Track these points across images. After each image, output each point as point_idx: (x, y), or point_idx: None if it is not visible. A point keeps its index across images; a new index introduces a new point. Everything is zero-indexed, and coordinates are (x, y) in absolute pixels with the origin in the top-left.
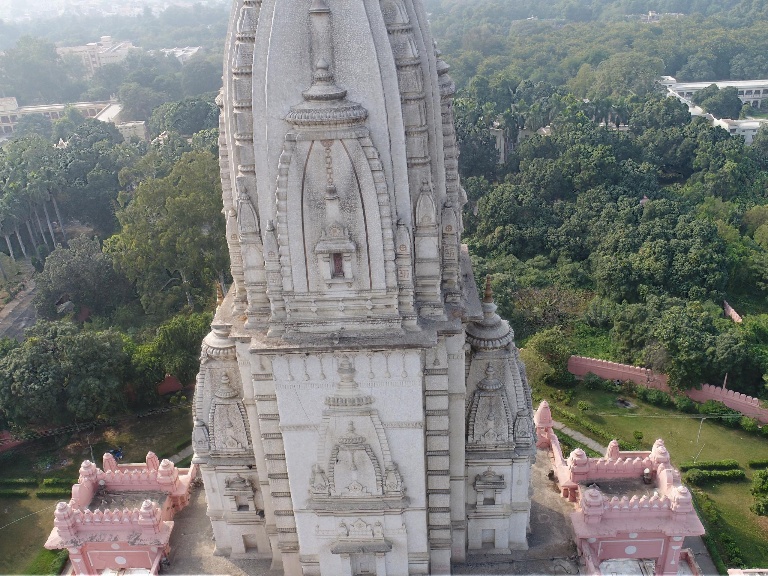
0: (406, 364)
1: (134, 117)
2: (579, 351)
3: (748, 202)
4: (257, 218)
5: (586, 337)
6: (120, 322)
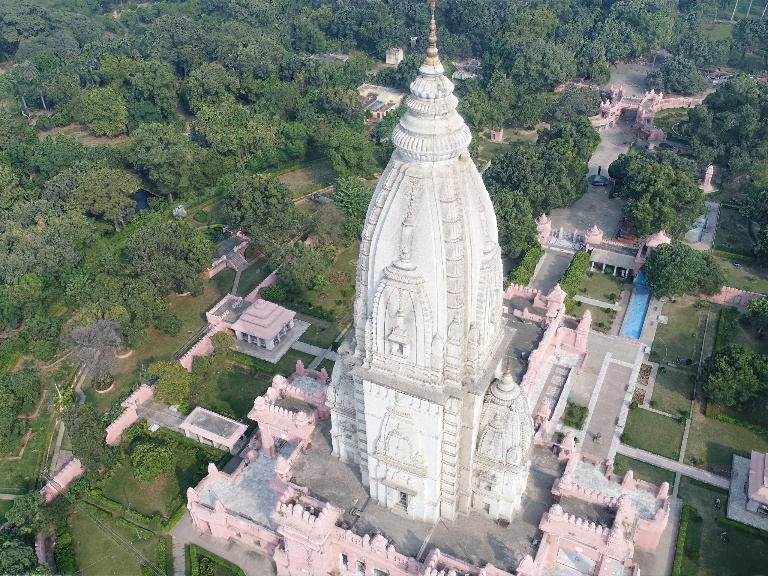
0: None
1: None
2: None
3: None
4: None
5: None
6: None
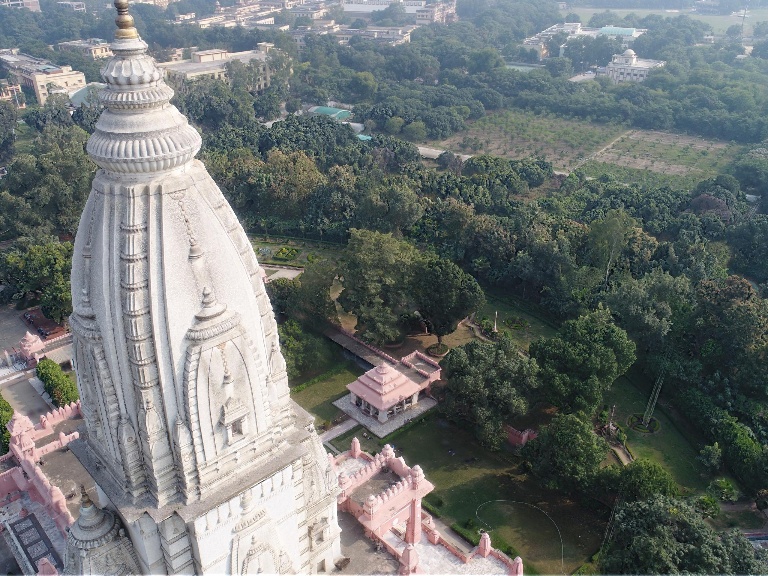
0: None
1: None
2: None
3: None
4: None
5: None
6: None
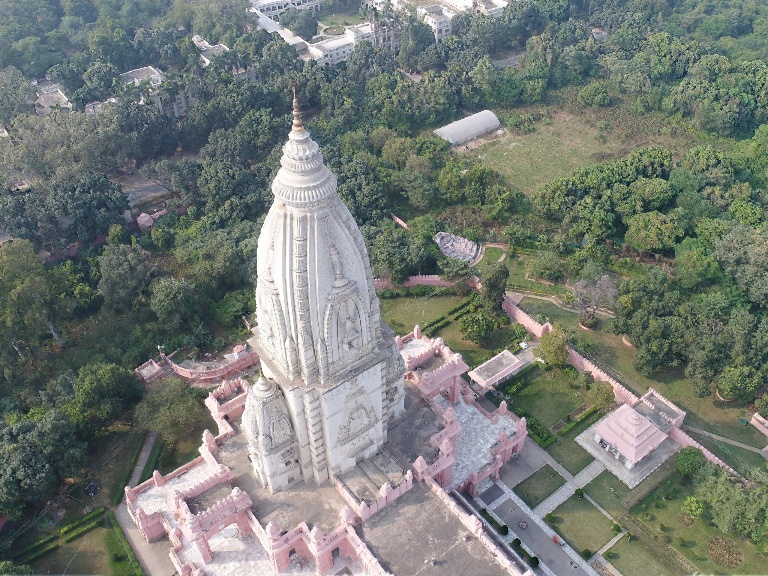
0: (376, 367)
1: None
2: None
3: (366, 125)
4: (311, 339)
5: None
6: None
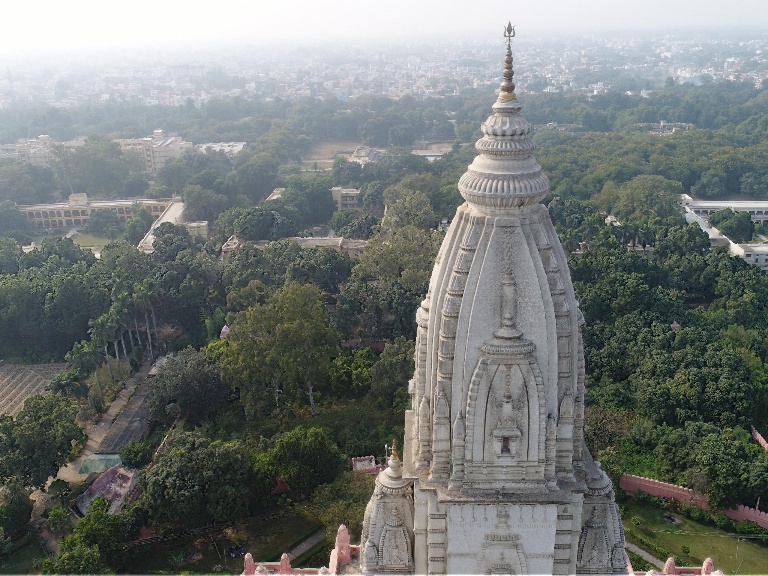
0: (547, 513)
1: (196, 216)
2: (627, 468)
3: (766, 328)
4: (449, 408)
5: (632, 455)
6: (224, 427)
